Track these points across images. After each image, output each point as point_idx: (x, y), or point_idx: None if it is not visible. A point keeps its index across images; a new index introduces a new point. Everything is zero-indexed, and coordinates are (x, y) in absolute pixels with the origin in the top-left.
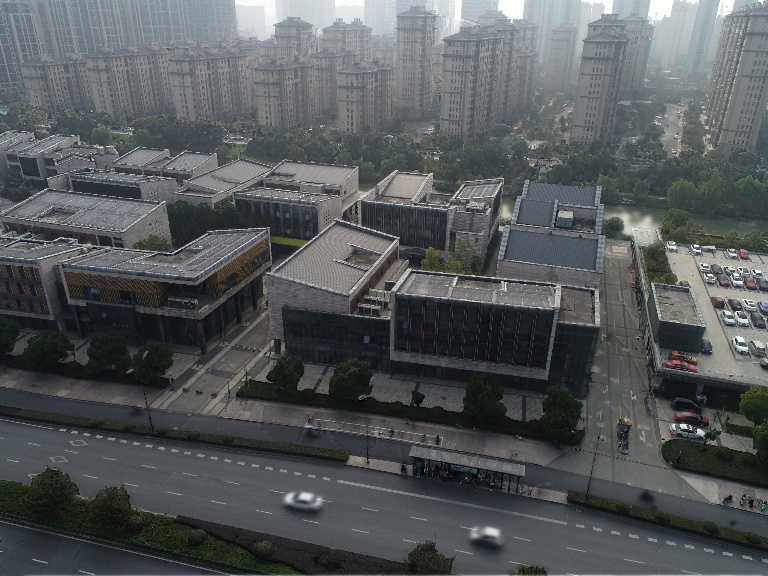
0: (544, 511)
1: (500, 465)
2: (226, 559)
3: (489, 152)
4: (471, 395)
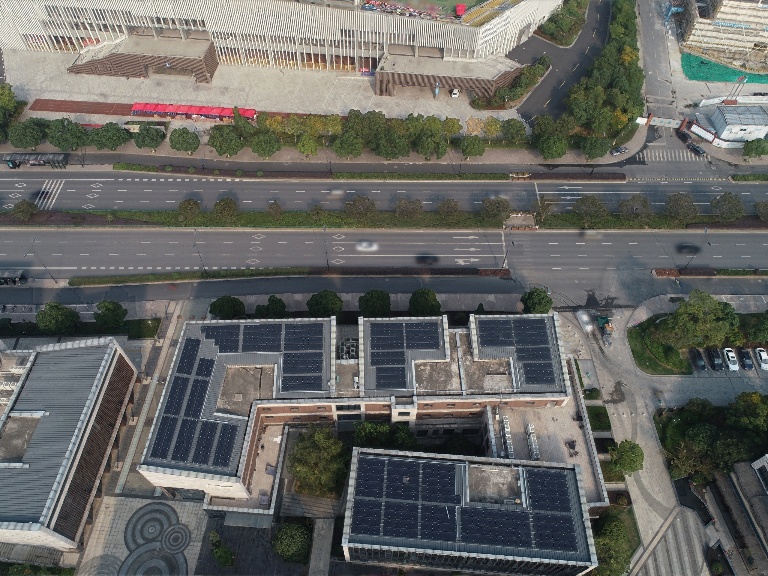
0: None
1: None
2: (129, 213)
3: None
4: None
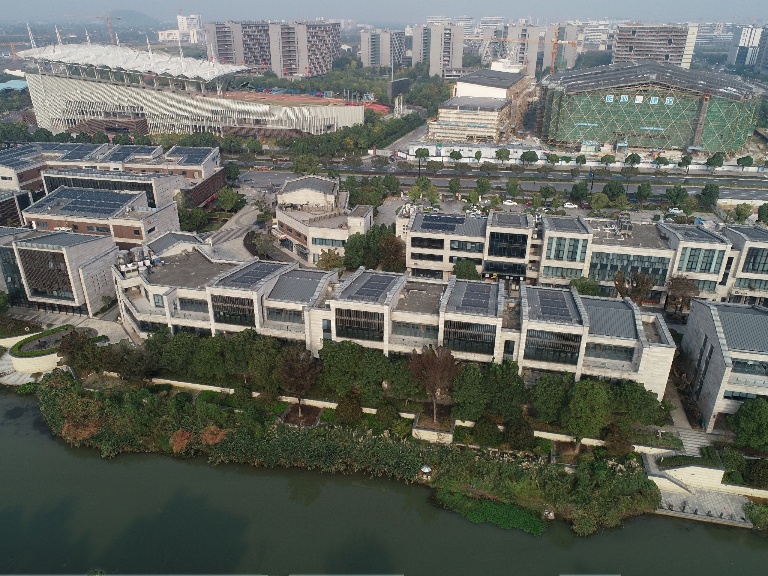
0: None
1: None
2: None
3: None
4: None
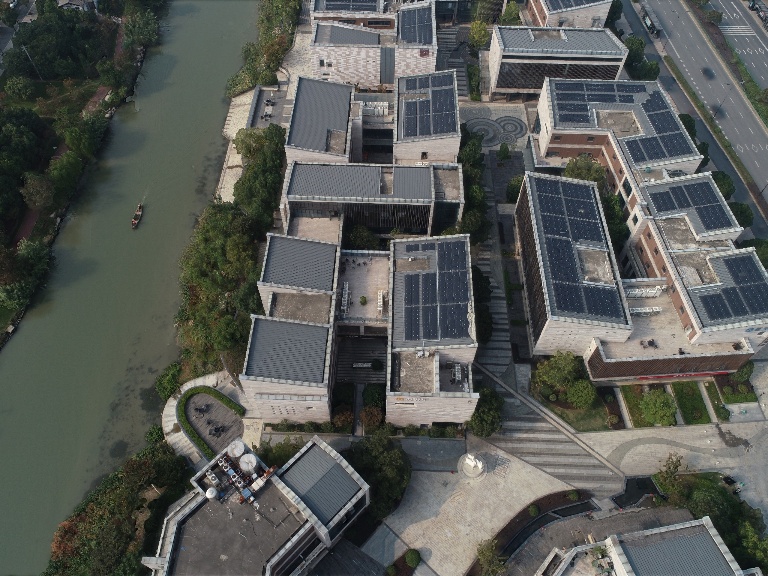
0: None
1: (648, 7)
2: (745, 70)
3: (61, 29)
4: None
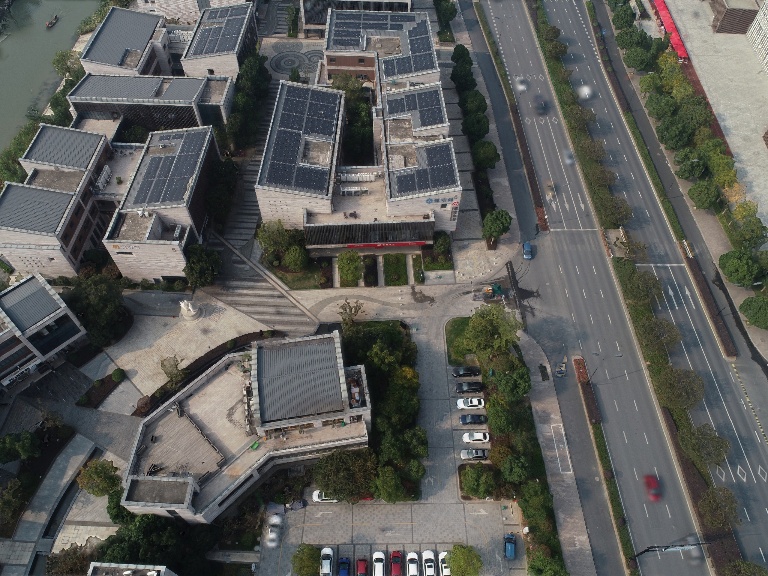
0: None
1: None
2: (543, 14)
3: None
4: None
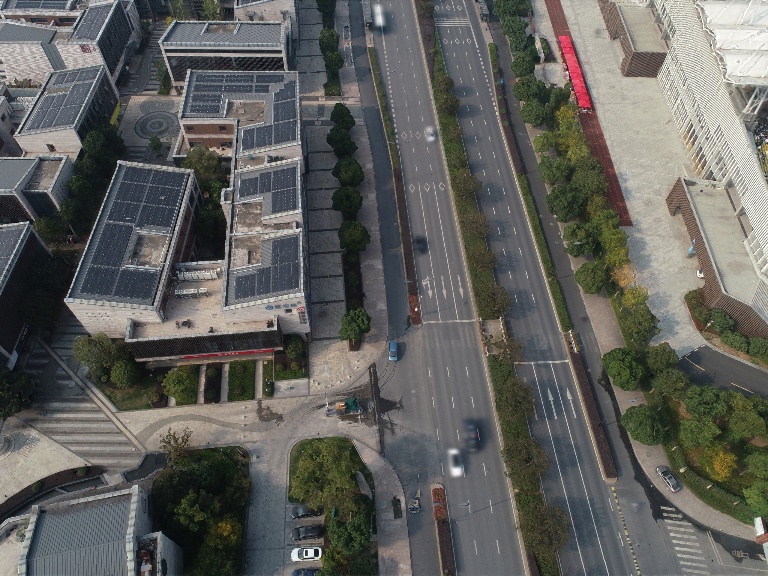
0: (374, 2)
1: (366, 1)
2: (441, 60)
3: None
4: (331, 2)
